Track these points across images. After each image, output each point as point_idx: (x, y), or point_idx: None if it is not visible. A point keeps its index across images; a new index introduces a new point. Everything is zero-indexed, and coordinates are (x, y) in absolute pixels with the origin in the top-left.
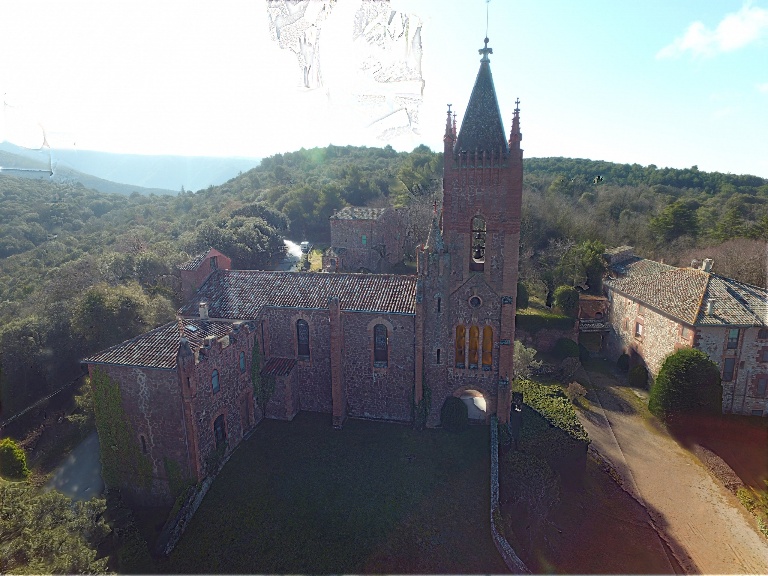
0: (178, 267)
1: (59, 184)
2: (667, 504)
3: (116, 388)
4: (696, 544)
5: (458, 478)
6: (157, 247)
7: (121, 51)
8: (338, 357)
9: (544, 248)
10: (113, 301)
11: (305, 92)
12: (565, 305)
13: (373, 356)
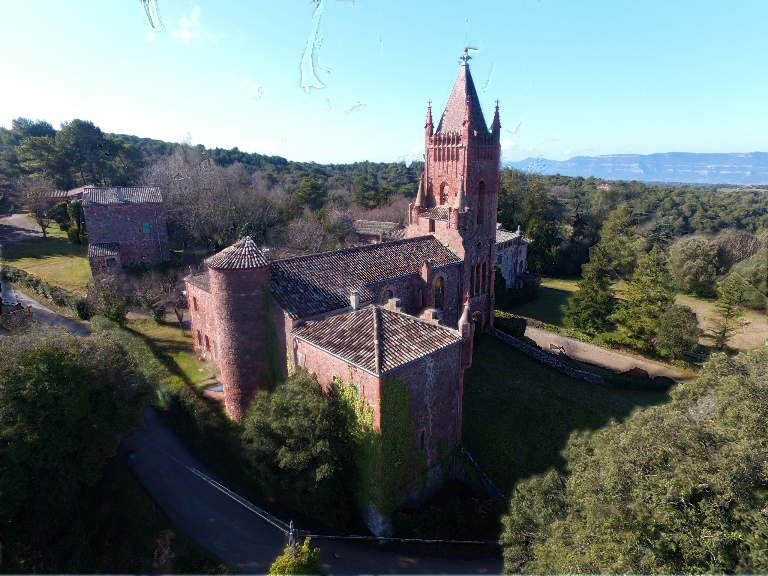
0: (236, 267)
1: None
2: (538, 343)
3: (406, 390)
4: (567, 351)
5: (519, 363)
6: None
7: None
8: None
9: None
10: (91, 352)
11: (153, 33)
12: None
13: None
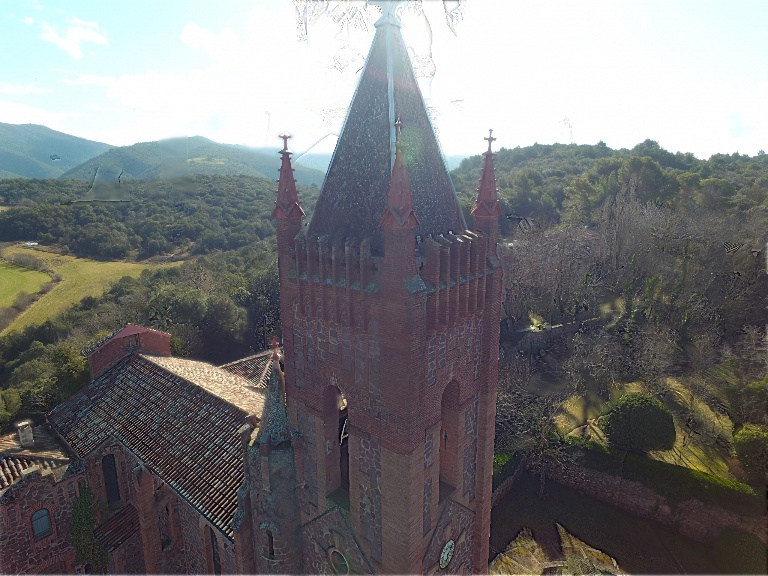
0: None
1: (174, 207)
2: None
3: None
4: None
5: None
6: (228, 278)
7: (11, 83)
8: (149, 560)
9: (732, 342)
10: (73, 363)
11: None
12: (753, 464)
13: (211, 570)
